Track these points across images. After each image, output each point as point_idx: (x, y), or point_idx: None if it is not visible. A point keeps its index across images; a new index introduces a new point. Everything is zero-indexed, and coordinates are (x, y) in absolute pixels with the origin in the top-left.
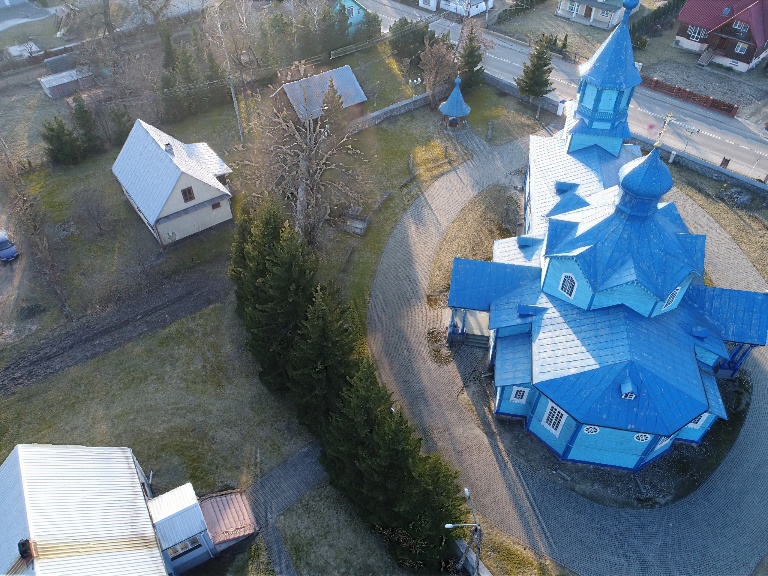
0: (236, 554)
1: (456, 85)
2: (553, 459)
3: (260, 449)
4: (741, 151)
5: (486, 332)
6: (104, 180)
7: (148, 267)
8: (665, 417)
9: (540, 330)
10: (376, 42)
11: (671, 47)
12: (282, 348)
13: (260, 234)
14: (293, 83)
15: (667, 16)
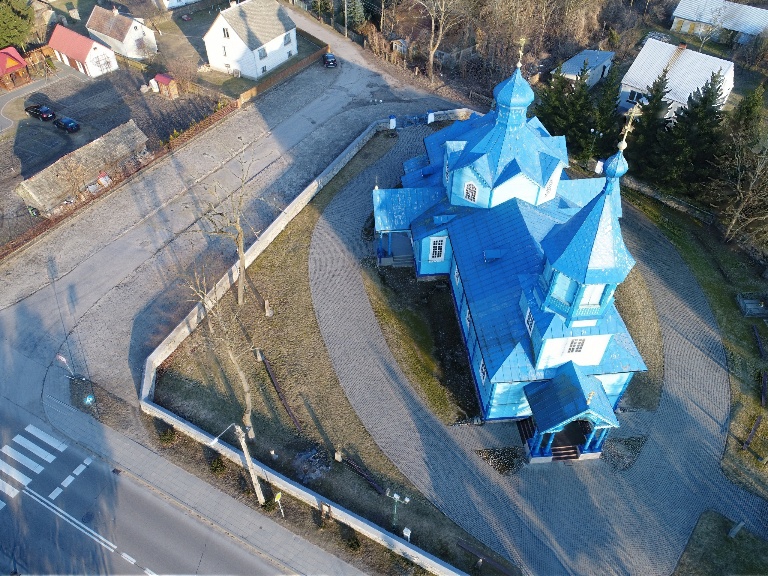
0: (621, 128)
1: None
2: None
3: None
4: None
5: None
6: None
7: None
8: None
9: None
10: None
11: None
12: None
13: None
14: None
15: None
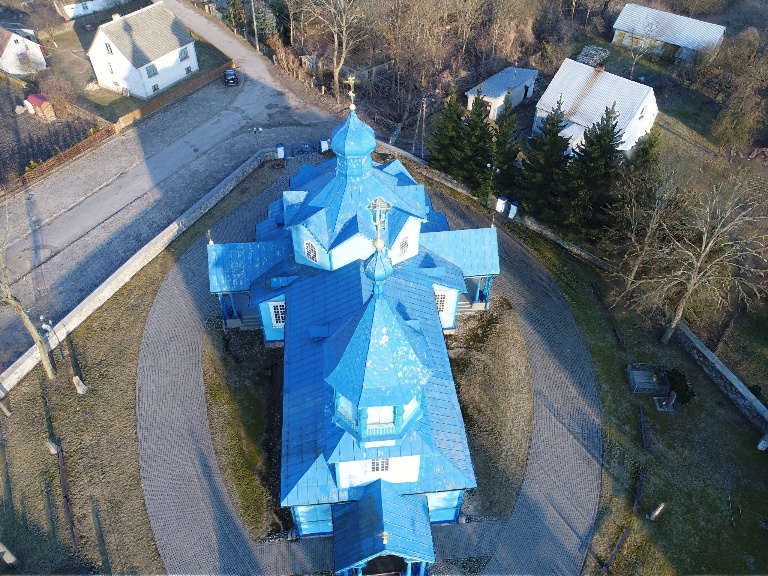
0: None
1: None
2: None
3: None
4: None
5: None
6: None
7: None
8: None
9: None
10: None
11: None
12: None
13: None
14: None
15: None
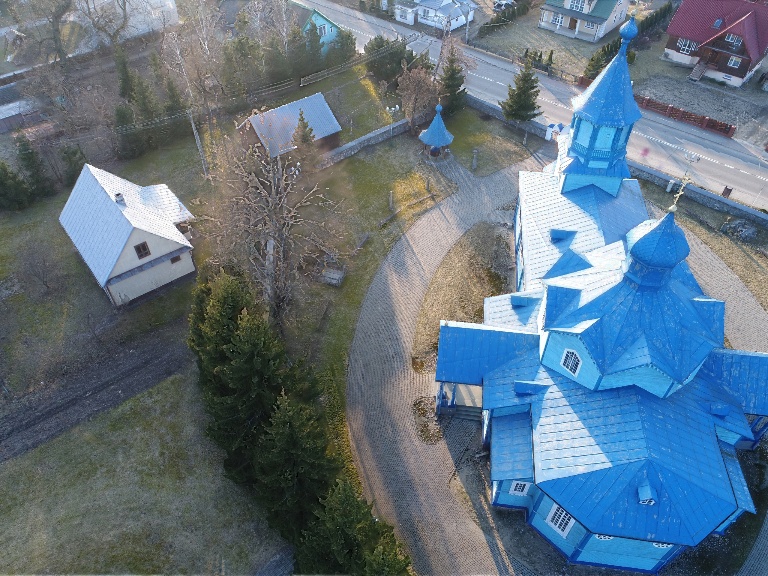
0: None
1: (437, 113)
2: (560, 560)
3: (225, 559)
4: (742, 177)
5: (479, 402)
6: (53, 228)
7: (100, 332)
8: (689, 524)
9: (541, 413)
10: (350, 66)
11: (660, 60)
12: (247, 441)
13: (217, 313)
14: None
15: (654, 26)
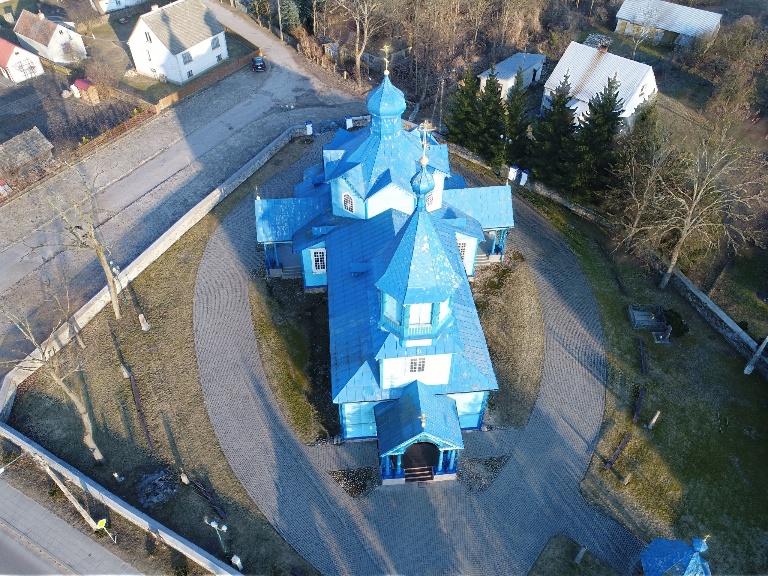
0: None
1: None
2: None
3: None
4: None
5: None
6: None
7: None
8: None
9: None
10: None
11: None
12: None
13: None
14: None
15: None
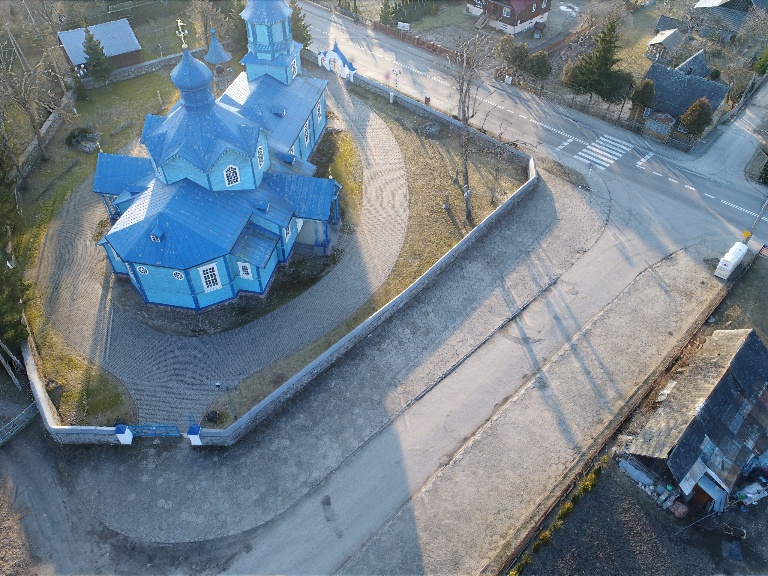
0: None
1: (212, 35)
2: (144, 304)
3: None
4: None
5: None
6: None
7: None
8: (184, 255)
9: (135, 202)
10: None
11: (462, 14)
12: None
13: None
14: (68, 32)
15: None
